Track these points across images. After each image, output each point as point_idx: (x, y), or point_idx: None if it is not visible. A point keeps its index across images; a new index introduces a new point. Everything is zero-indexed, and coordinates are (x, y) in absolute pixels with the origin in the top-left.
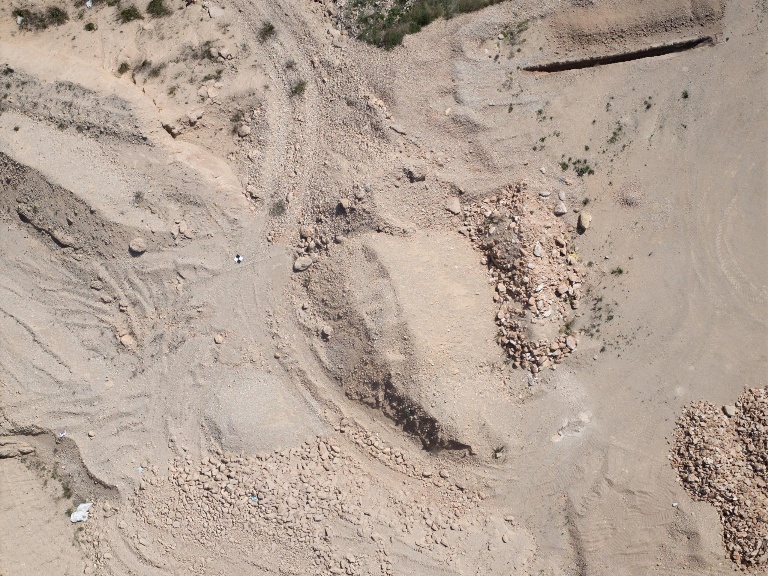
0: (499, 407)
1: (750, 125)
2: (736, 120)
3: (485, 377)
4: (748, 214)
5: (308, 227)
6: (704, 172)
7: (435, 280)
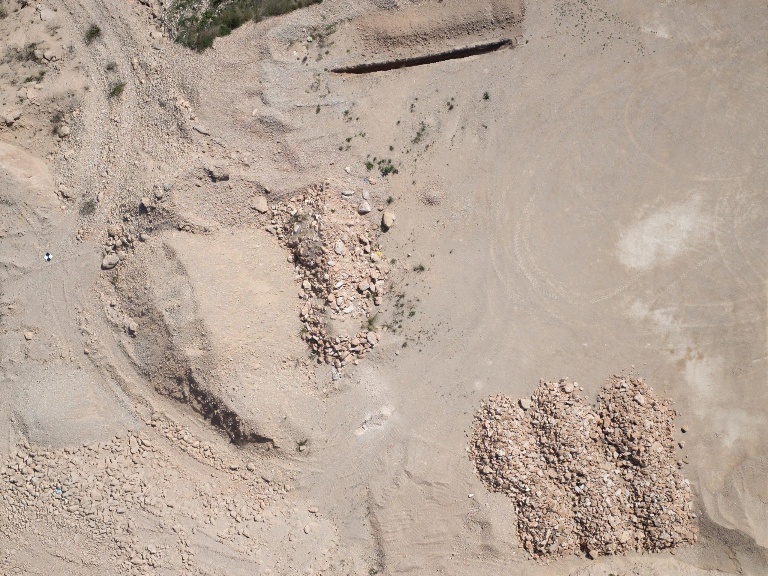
0: (302, 401)
1: (548, 126)
2: (535, 121)
3: (289, 372)
4: (545, 212)
5: (115, 226)
6: (504, 171)
7: (236, 277)
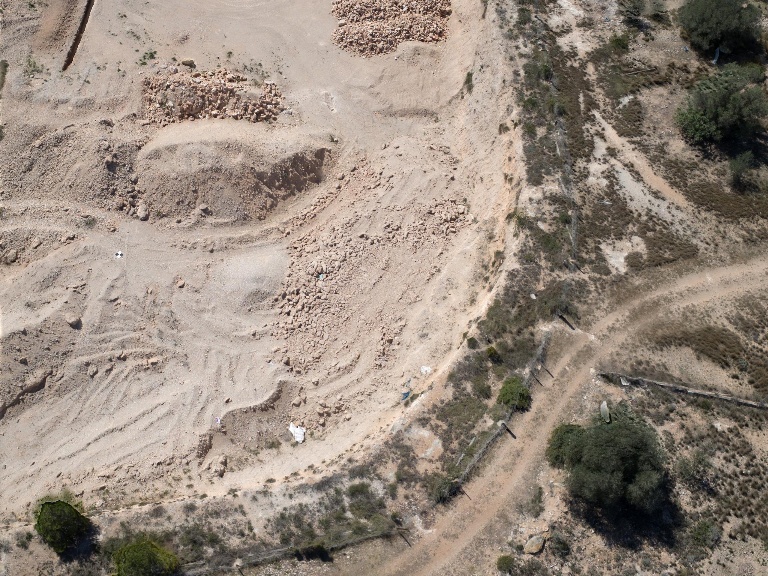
0: None
1: None
2: None
3: None
4: None
5: (115, 201)
6: (182, 1)
7: None
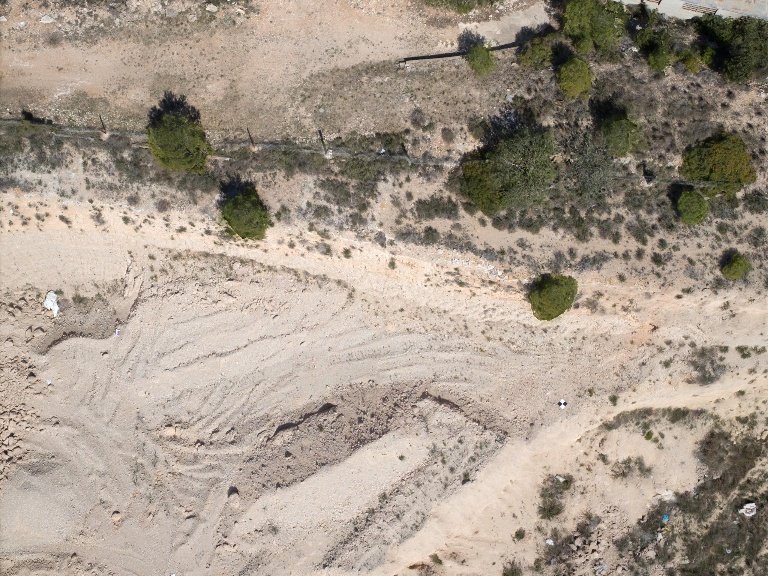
0: None
1: None
2: None
3: None
4: None
5: None
6: None
7: None
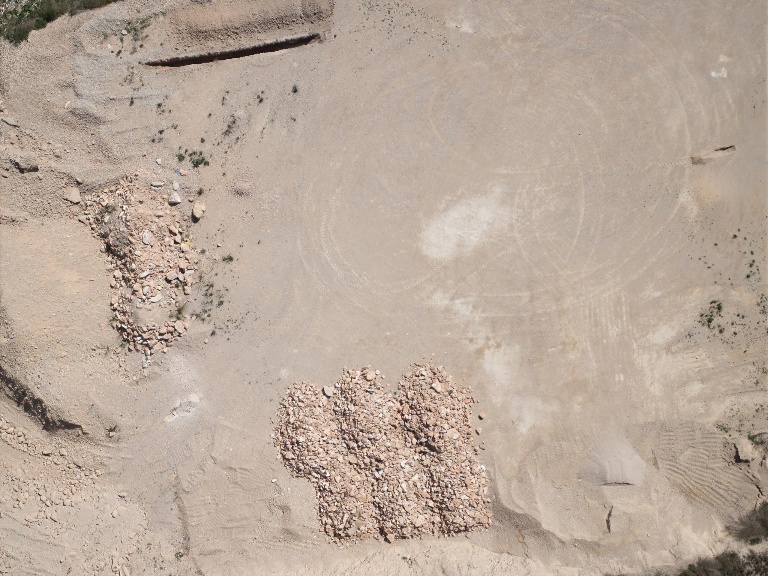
0: (111, 388)
1: (354, 119)
2: (341, 114)
3: (98, 360)
4: (351, 204)
5: None
6: (311, 164)
7: (44, 267)
